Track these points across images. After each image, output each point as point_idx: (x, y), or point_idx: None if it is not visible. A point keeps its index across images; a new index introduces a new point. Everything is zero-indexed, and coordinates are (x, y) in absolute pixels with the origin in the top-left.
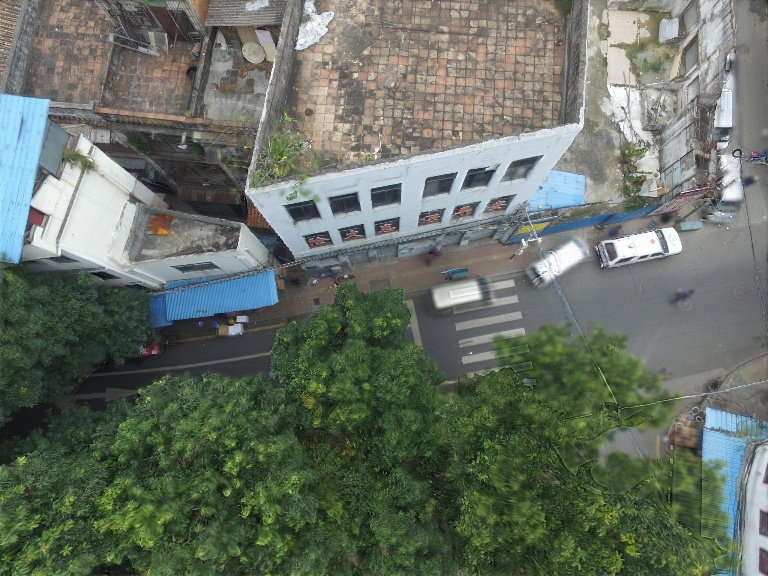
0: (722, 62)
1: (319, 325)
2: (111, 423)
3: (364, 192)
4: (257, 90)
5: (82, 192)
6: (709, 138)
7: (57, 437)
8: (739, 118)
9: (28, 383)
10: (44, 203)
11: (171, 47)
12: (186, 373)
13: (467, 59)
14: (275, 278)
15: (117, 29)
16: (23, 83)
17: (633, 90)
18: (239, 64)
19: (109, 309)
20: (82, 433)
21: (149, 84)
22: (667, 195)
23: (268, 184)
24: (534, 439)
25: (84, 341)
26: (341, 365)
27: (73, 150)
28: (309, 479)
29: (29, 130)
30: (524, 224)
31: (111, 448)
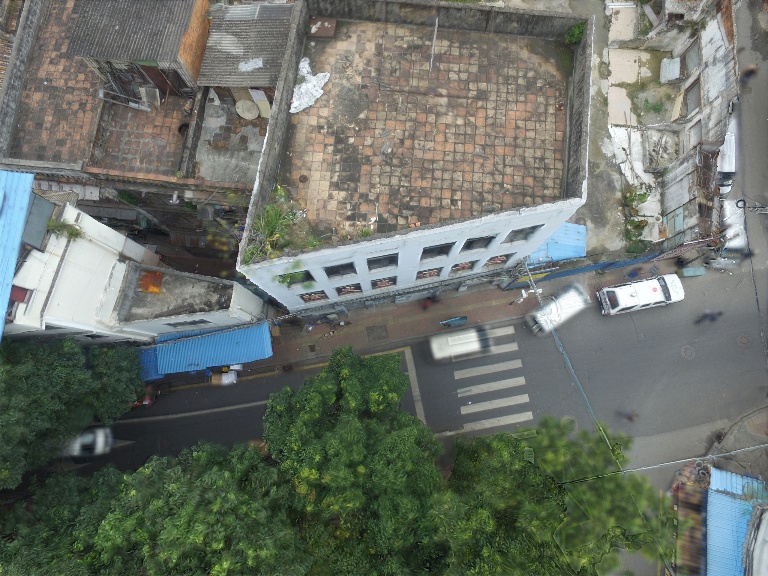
0: (725, 109)
1: (313, 398)
2: (96, 502)
3: (360, 261)
4: (251, 147)
5: (68, 260)
6: (712, 185)
7: (41, 510)
8: (742, 160)
9: (10, 463)
10: (27, 279)
11: (163, 102)
12: (178, 422)
13: (466, 124)
14: (269, 330)
15: (107, 85)
16: (10, 139)
17: (634, 131)
18: (232, 120)
19: (97, 371)
20: (66, 511)
21: (140, 140)
22: (669, 241)
23: (260, 261)
24: (536, 545)
25: (71, 404)
26: (335, 448)
27: (59, 220)
28: (301, 575)
29: (12, 206)
30: (524, 275)
31: (94, 540)
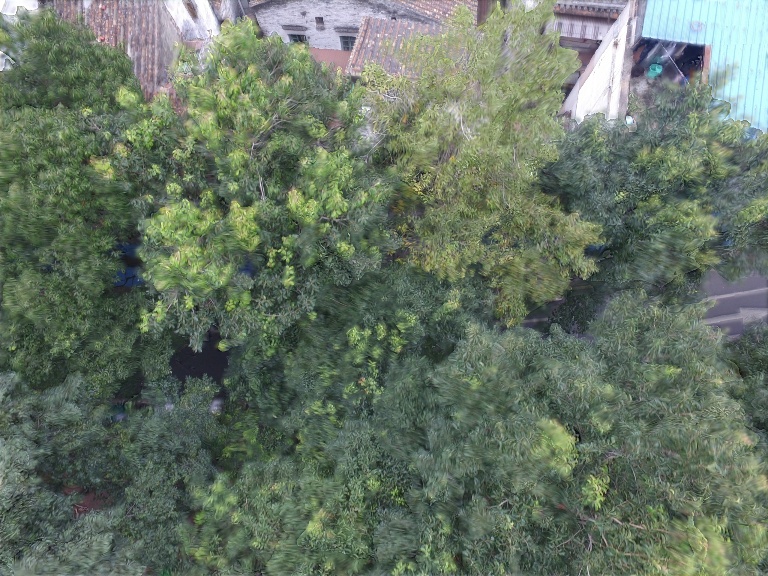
0: None
1: None
2: (764, 349)
3: None
4: None
5: None
6: None
7: None
8: None
9: None
10: None
11: None
12: None
13: None
14: None
15: None
16: None
17: None
18: None
19: None
20: None
21: None
22: None
23: None
24: None
25: None
26: None
27: None
28: None
29: None
30: None
31: None
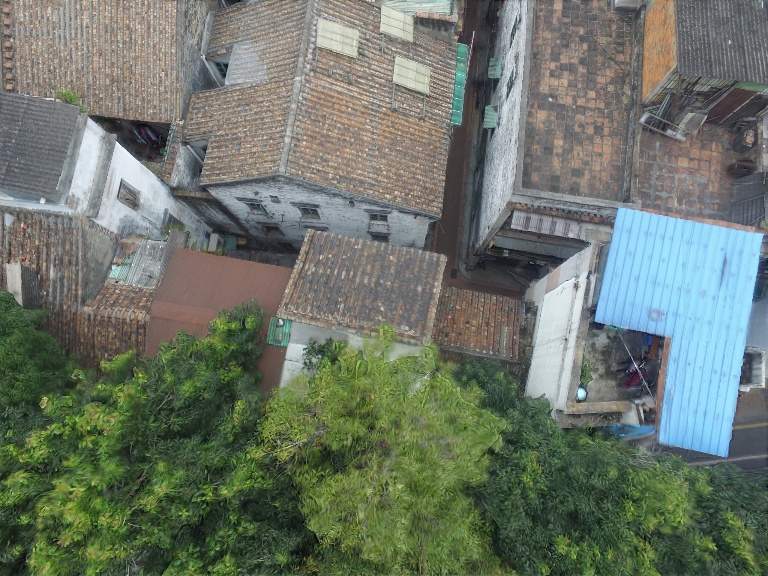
0: None
1: None
2: None
3: None
4: None
5: None
6: None
7: None
8: None
9: None
10: None
11: None
12: None
13: None
14: None
15: (650, 107)
16: None
17: None
18: None
19: None
20: None
21: (674, 176)
22: None
23: None
24: None
25: None
26: None
27: None
28: None
29: (736, 274)
30: None
31: None
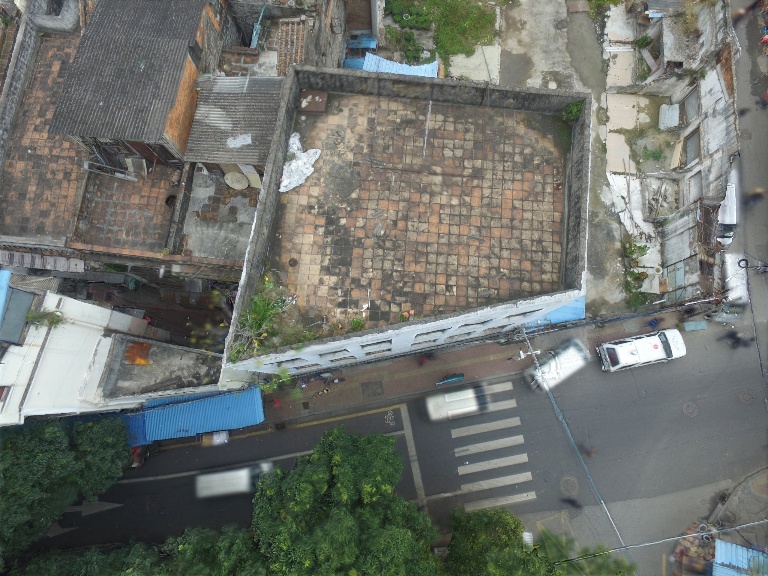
0: (726, 164)
1: (303, 490)
2: None
3: (352, 347)
4: (240, 219)
5: (49, 348)
6: (713, 239)
7: None
8: (742, 208)
9: None
10: (4, 376)
11: (150, 171)
12: (168, 484)
13: (461, 204)
14: (261, 394)
15: (92, 156)
16: None
17: (633, 178)
18: (221, 190)
19: (81, 449)
20: None
21: (126, 211)
22: (670, 294)
23: (247, 358)
24: None
25: (54, 484)
26: (325, 553)
27: (38, 310)
28: None
29: None
30: None
31: None
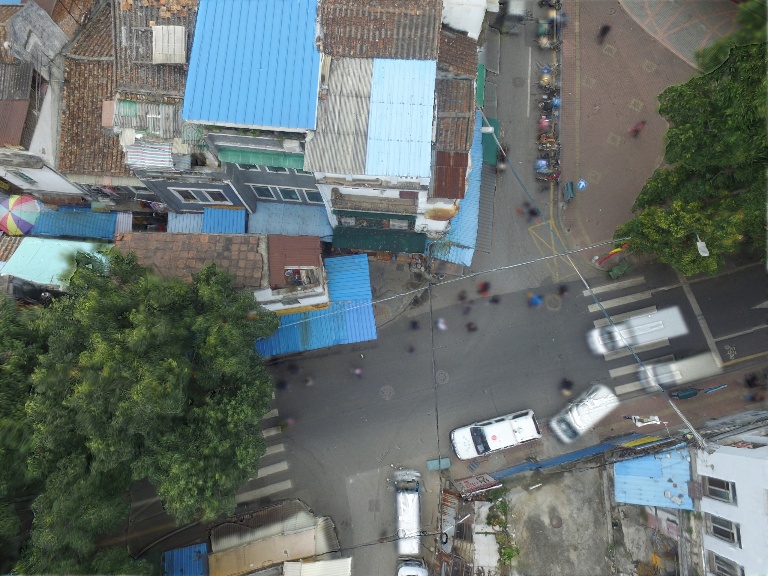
0: None
1: None
2: None
3: None
4: None
5: None
6: (446, 571)
7: None
8: None
9: None
10: None
11: None
12: None
13: None
14: None
15: None
16: None
17: None
18: None
19: None
20: None
21: None
22: None
23: None
24: None
25: None
26: None
27: None
28: None
29: None
30: None
31: None
